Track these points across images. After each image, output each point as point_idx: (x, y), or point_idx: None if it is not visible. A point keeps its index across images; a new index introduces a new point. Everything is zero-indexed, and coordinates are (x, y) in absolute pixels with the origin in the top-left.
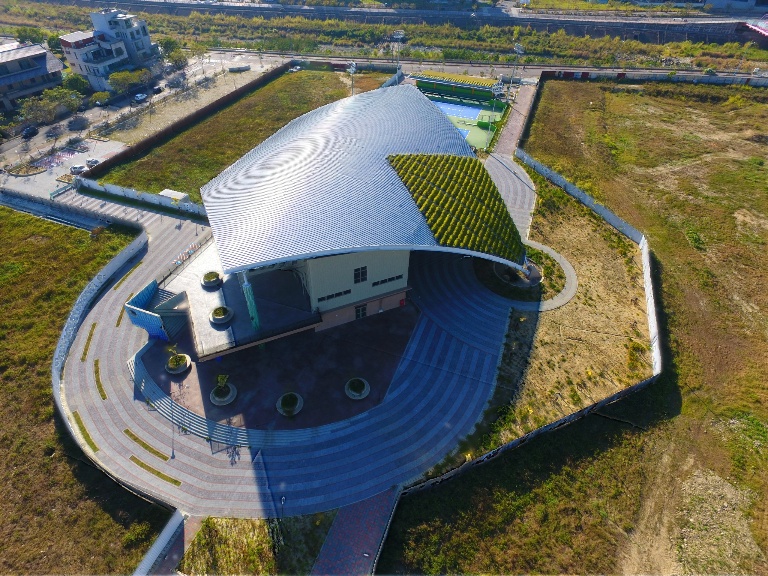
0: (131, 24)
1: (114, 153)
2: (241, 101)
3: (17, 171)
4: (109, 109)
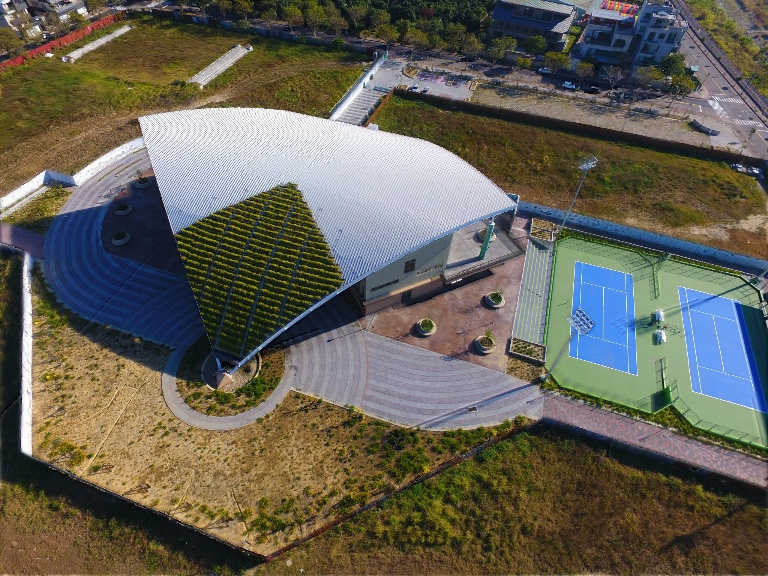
0: (664, 25)
1: (450, 97)
2: (601, 141)
3: (408, 69)
4: (534, 78)
